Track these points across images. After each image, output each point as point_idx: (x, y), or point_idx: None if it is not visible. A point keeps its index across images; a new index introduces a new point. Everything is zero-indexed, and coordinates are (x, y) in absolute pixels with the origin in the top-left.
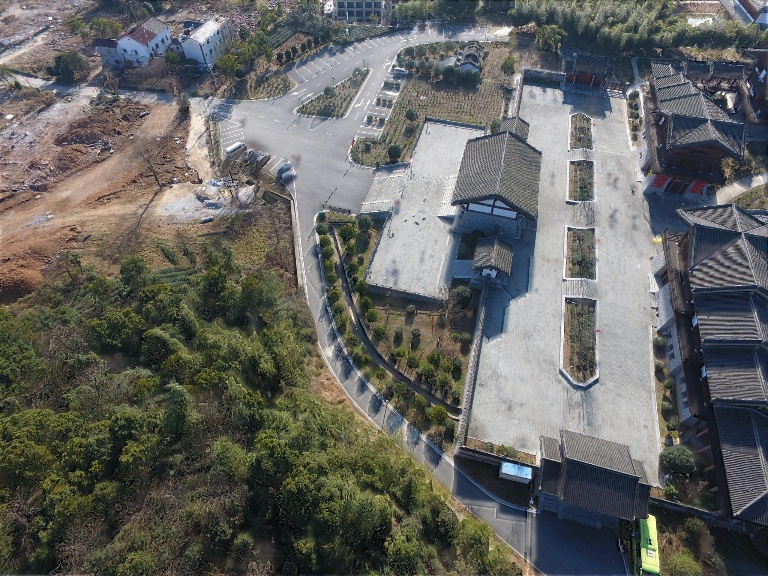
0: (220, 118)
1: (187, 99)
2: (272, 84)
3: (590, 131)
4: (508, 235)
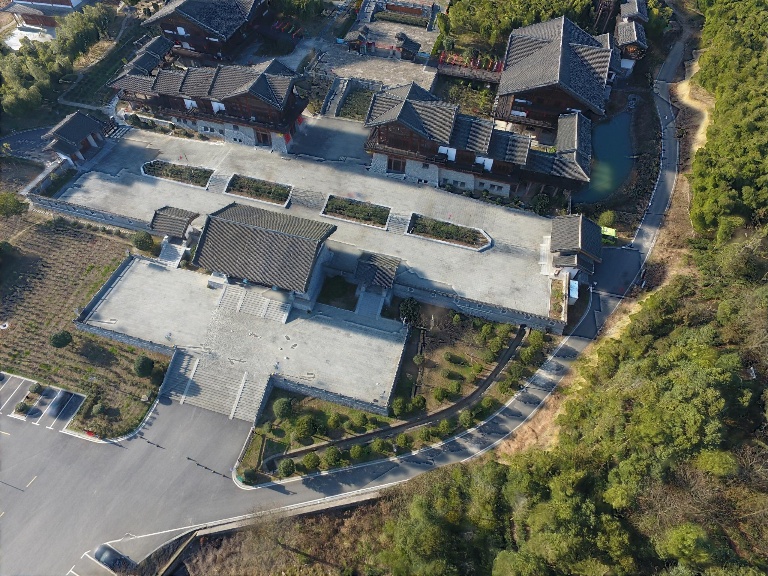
0: None
1: None
2: None
3: (179, 166)
4: (329, 260)
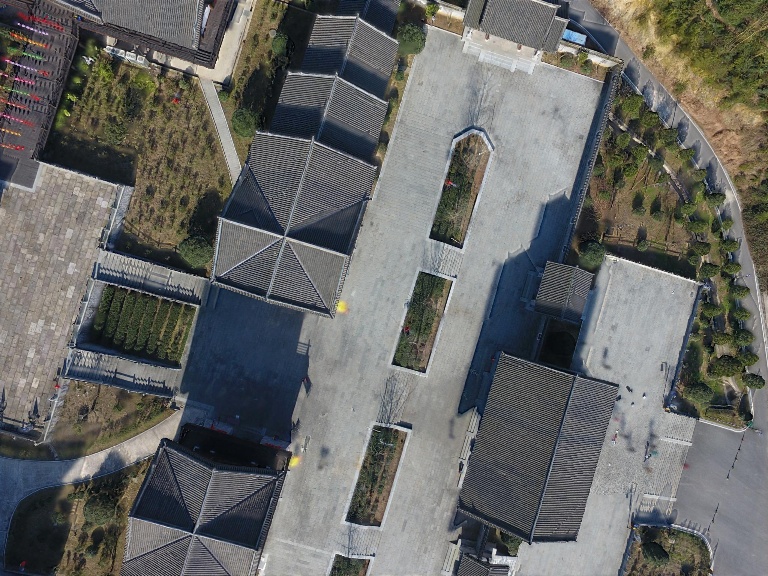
0: None
1: None
2: None
3: None
4: None
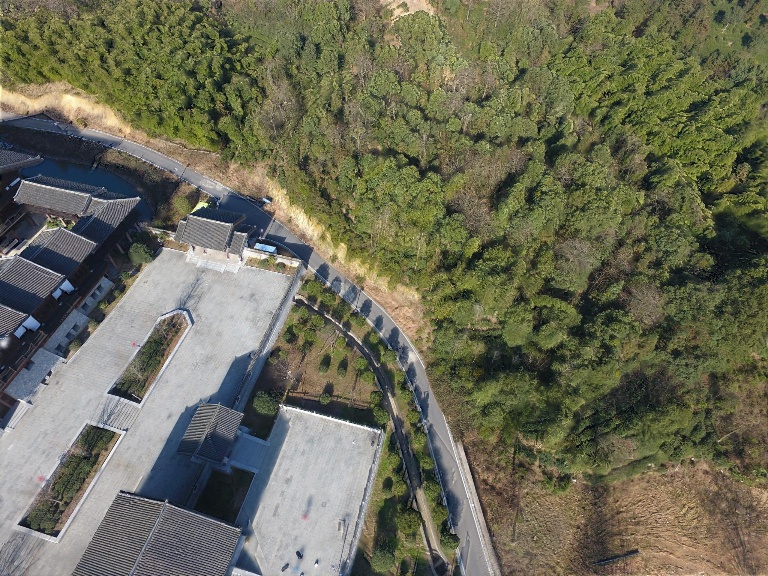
0: None
1: None
2: None
3: None
4: None
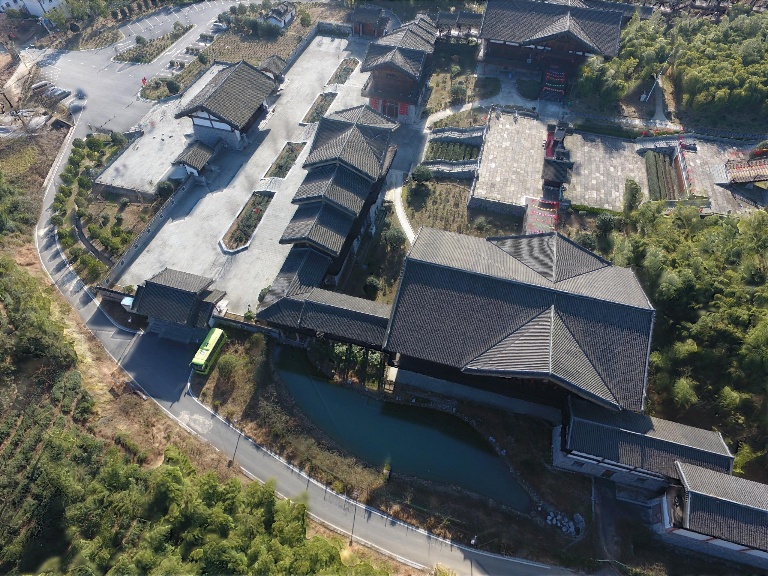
0: (45, 64)
1: (16, 48)
2: (102, 37)
3: (353, 71)
4: (232, 147)
